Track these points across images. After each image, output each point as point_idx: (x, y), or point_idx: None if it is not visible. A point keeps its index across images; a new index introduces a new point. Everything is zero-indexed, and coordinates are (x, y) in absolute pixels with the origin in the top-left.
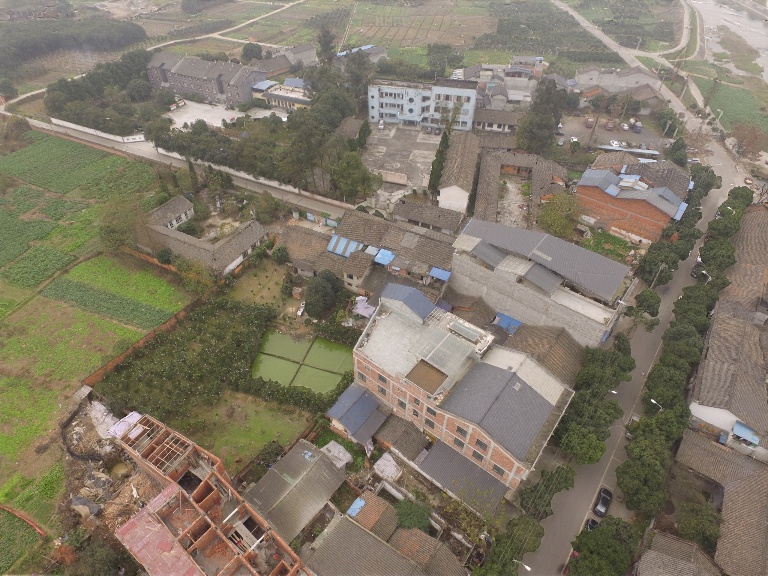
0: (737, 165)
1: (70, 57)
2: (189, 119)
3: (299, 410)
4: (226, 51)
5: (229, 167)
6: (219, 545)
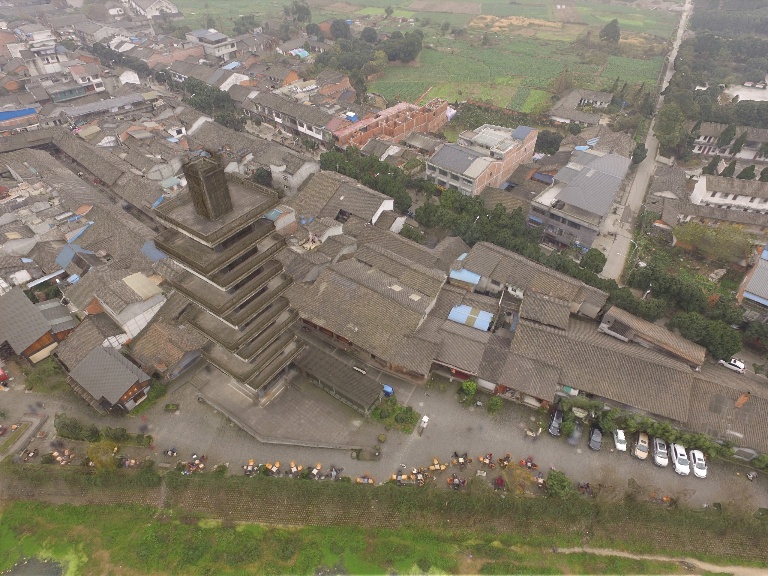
0: None
1: None
2: (739, 93)
3: None
4: None
5: None
6: None
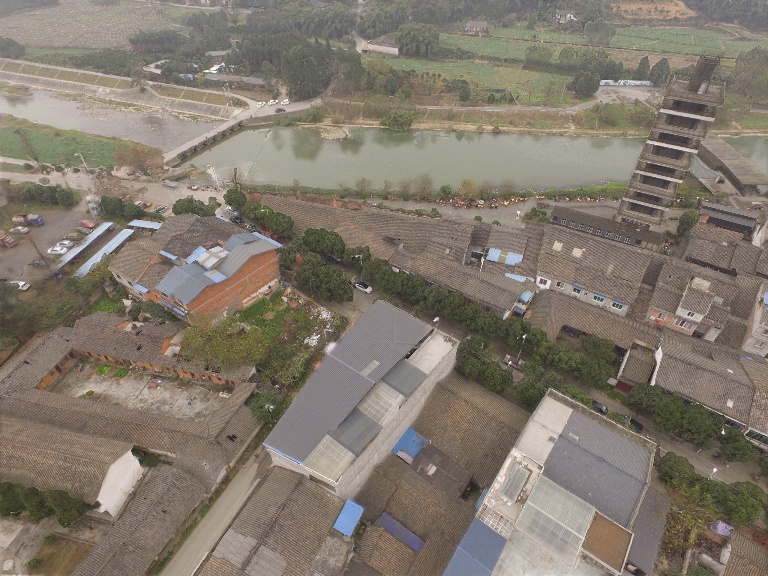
0: (166, 183)
1: None
2: None
3: None
4: None
5: None
6: None
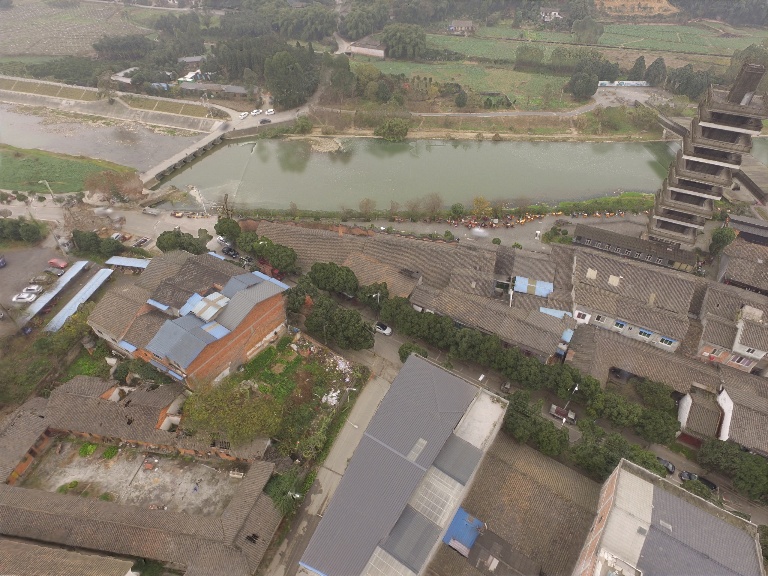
0: (146, 211)
1: None
2: None
3: None
4: None
5: None
6: None
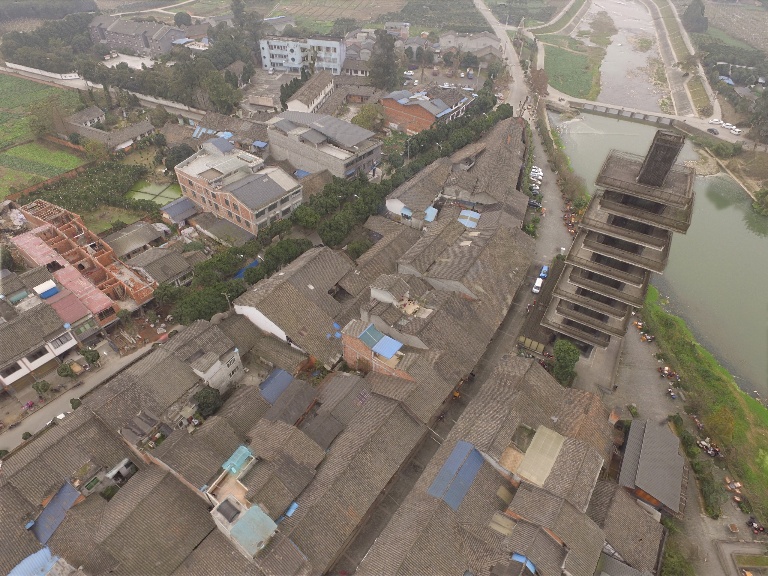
0: None
1: (29, 23)
2: None
3: (147, 214)
4: (165, 21)
5: (139, 93)
6: (72, 252)
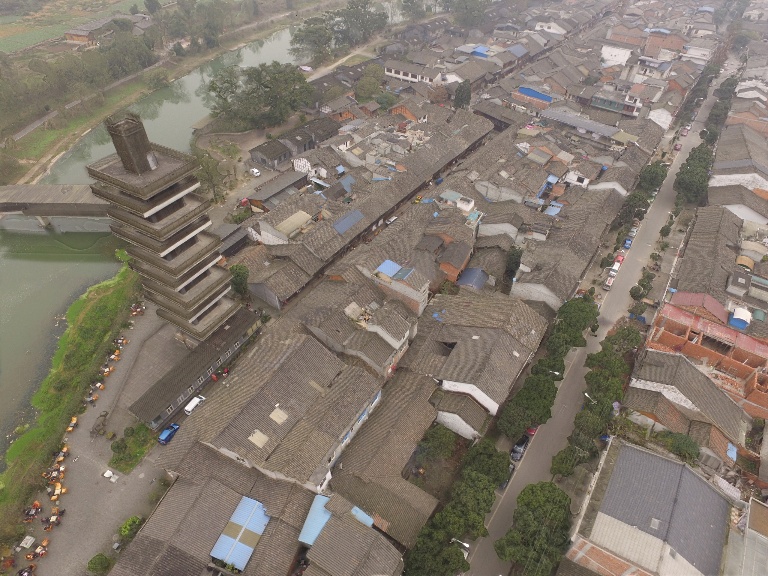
0: None
1: None
2: None
3: None
4: None
5: None
6: None
